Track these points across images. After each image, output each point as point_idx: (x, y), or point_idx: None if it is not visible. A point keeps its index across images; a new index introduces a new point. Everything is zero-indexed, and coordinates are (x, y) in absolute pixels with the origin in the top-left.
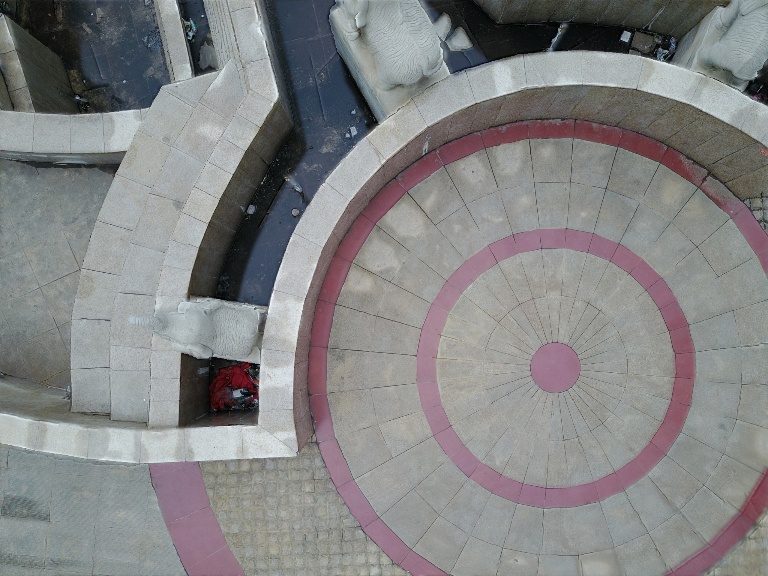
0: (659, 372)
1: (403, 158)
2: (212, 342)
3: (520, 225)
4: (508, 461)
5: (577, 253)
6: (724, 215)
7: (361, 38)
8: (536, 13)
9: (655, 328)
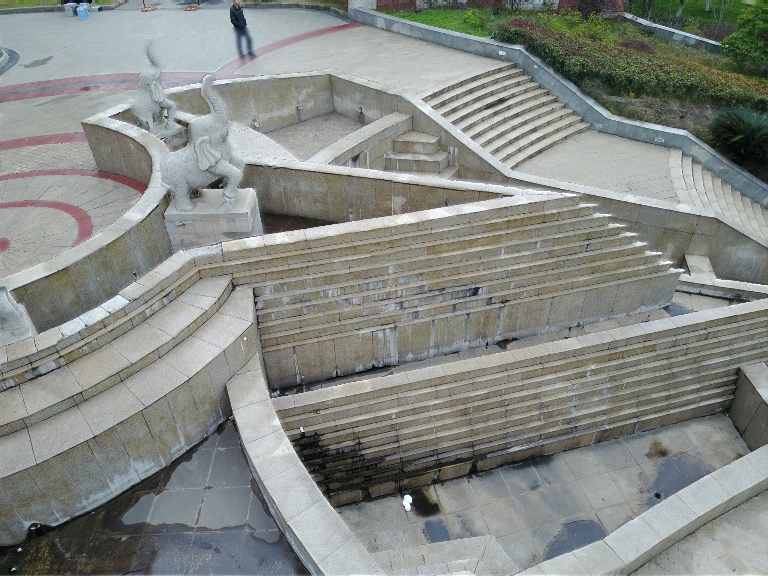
0: None
1: None
2: None
3: None
4: None
5: None
6: None
7: None
8: None
9: None
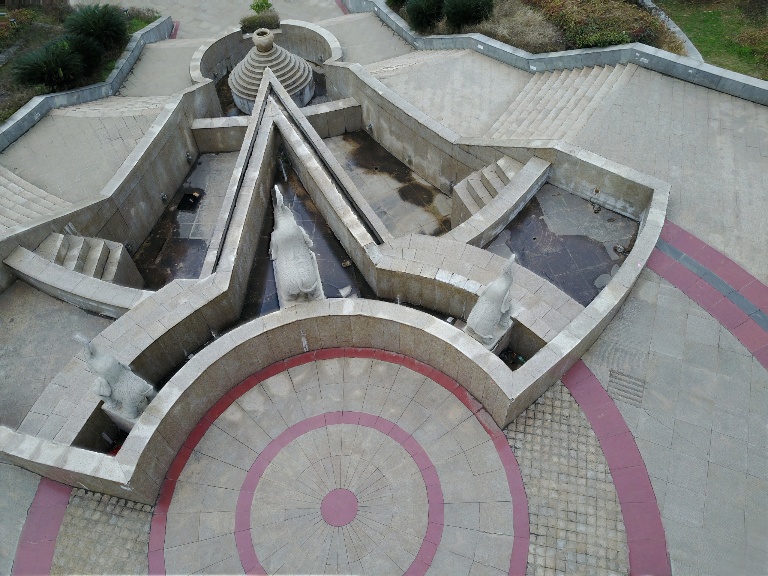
0: (413, 532)
1: (286, 342)
2: (114, 384)
3: (349, 406)
4: (279, 568)
5: (381, 433)
6: (487, 436)
7: None
8: (397, 294)
9: (419, 499)
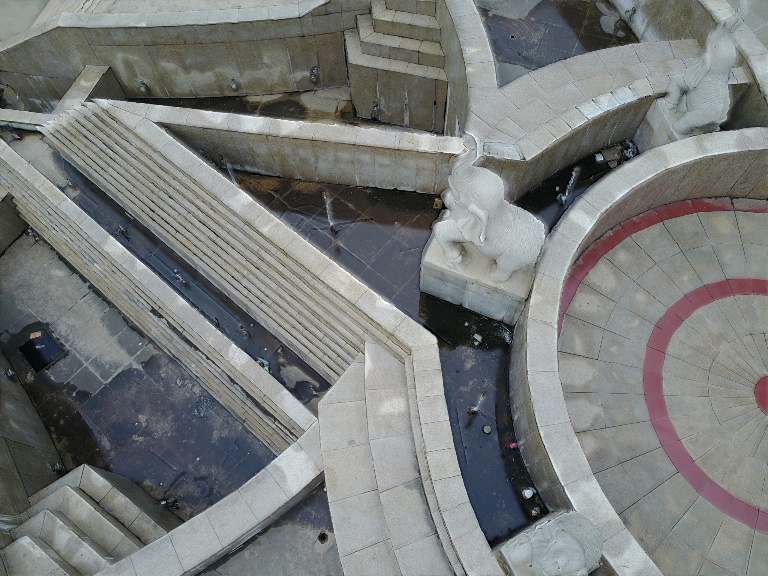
0: None
1: None
2: None
3: (653, 316)
4: None
5: (708, 306)
6: (766, 215)
7: (462, 259)
8: (537, 178)
9: None
